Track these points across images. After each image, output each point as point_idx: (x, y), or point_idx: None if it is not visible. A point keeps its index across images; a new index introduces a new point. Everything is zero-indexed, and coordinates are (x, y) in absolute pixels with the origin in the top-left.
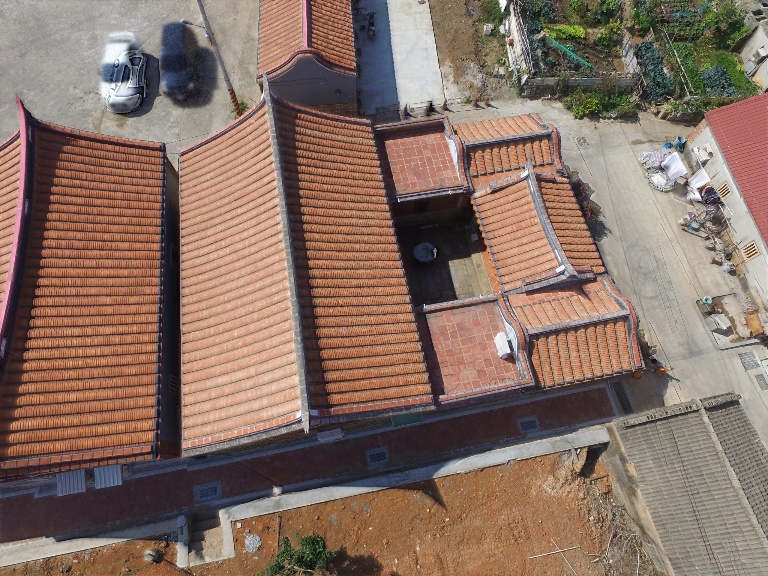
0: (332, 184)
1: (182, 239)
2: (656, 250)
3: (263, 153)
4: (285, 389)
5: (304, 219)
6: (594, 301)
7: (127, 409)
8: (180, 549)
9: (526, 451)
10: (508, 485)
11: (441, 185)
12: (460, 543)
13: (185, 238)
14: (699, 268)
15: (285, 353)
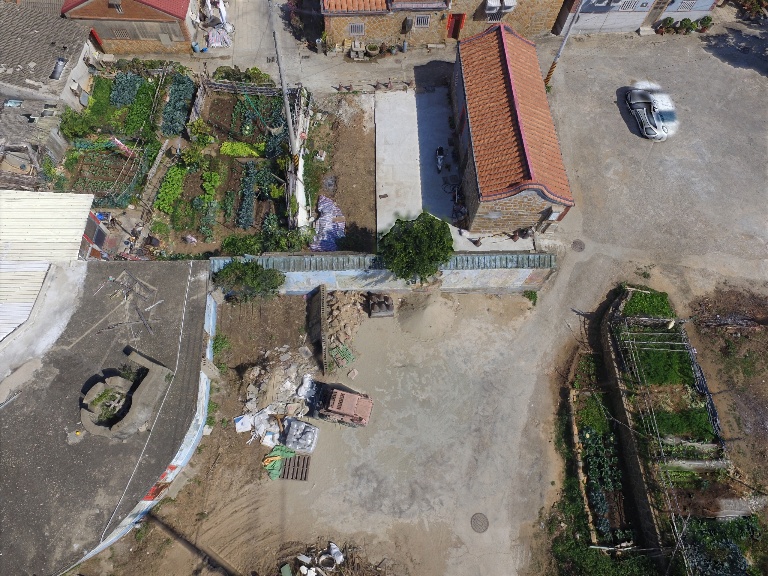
0: None
1: None
2: None
3: None
4: None
5: None
6: None
7: None
8: None
9: None
10: None
11: None
12: None
13: None
14: None
15: None
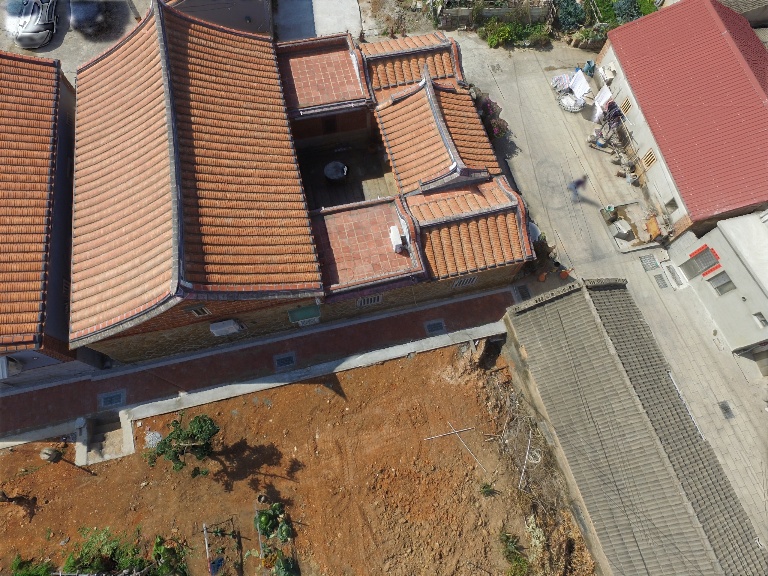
0: (227, 91)
1: (76, 150)
2: (564, 166)
3: (153, 60)
4: (164, 271)
5: (193, 120)
6: (487, 197)
7: (9, 302)
8: (78, 449)
9: (426, 344)
10: (408, 376)
11: (344, 98)
12: (359, 430)
13: (79, 149)
14: (604, 181)
15: (166, 239)
